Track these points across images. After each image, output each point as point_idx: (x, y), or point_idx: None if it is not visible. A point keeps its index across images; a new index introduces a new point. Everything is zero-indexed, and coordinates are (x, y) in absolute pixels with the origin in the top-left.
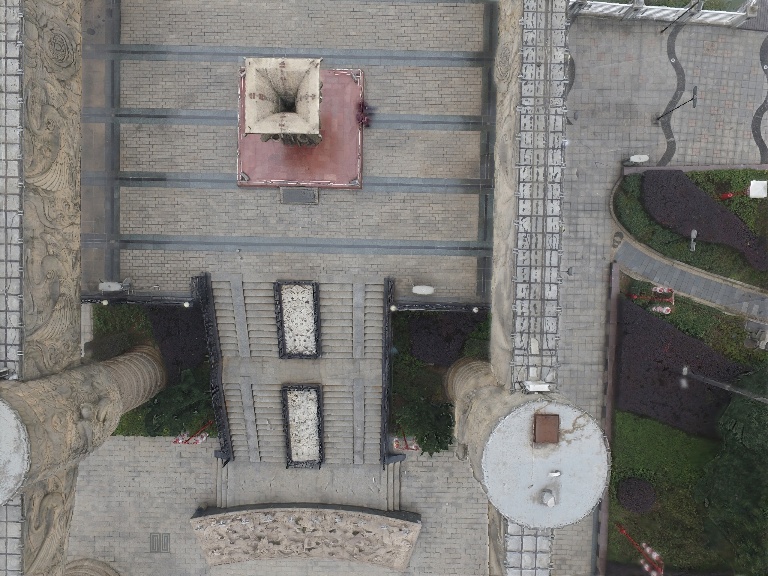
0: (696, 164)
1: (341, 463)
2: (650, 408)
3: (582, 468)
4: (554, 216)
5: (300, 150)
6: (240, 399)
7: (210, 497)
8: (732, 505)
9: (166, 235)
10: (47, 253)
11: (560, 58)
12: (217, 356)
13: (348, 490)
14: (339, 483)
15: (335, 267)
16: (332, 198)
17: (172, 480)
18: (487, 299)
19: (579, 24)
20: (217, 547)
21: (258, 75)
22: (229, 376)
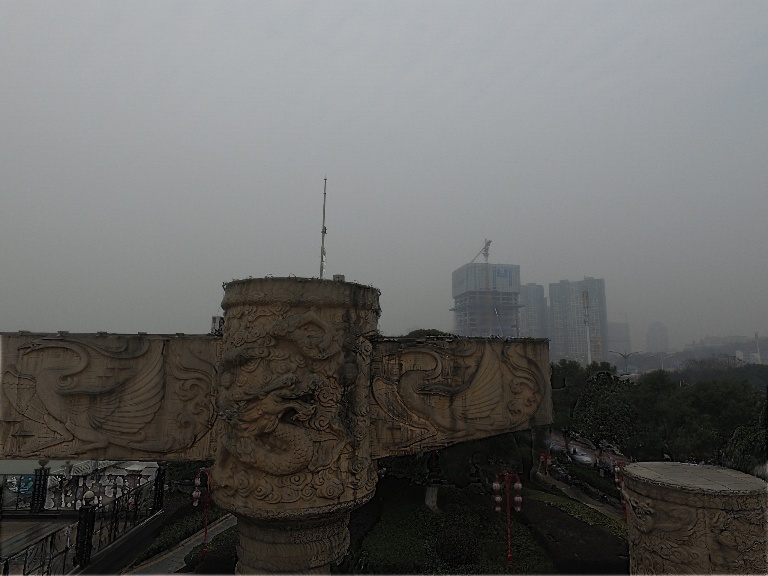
0: None
1: None
2: None
3: None
4: None
5: None
6: None
7: None
8: None
9: None
10: None
11: None
12: None
13: None
14: None
15: None
16: None
17: None
18: None
19: None
20: None
21: None
22: None
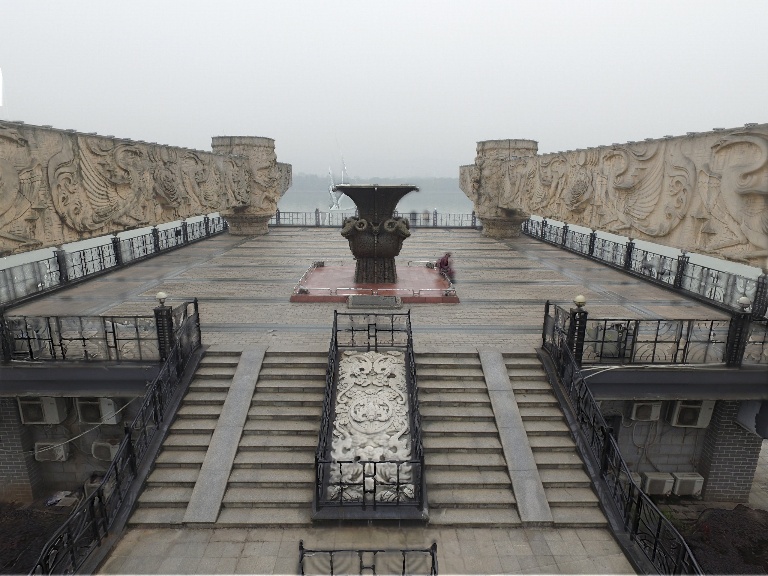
0: None
1: None
2: None
3: None
4: None
5: None
6: None
7: None
8: None
9: None
10: None
11: None
12: (116, 514)
13: None
14: None
15: (439, 341)
16: None
17: None
18: None
19: None
20: None
21: None
22: None
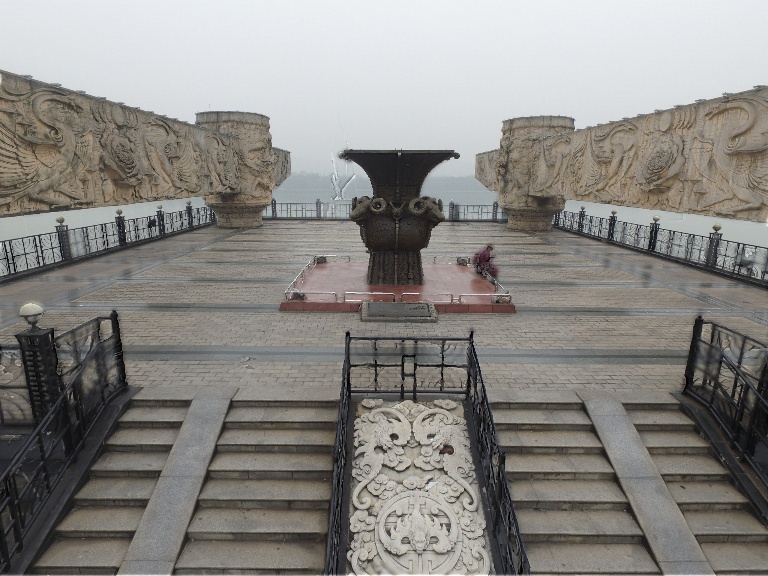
0: None
1: None
2: None
3: None
4: None
5: (396, 287)
6: None
7: None
8: None
9: None
10: None
11: None
12: None
13: None
14: None
15: (511, 379)
16: (463, 318)
17: None
18: None
19: None
20: None
21: None
22: None
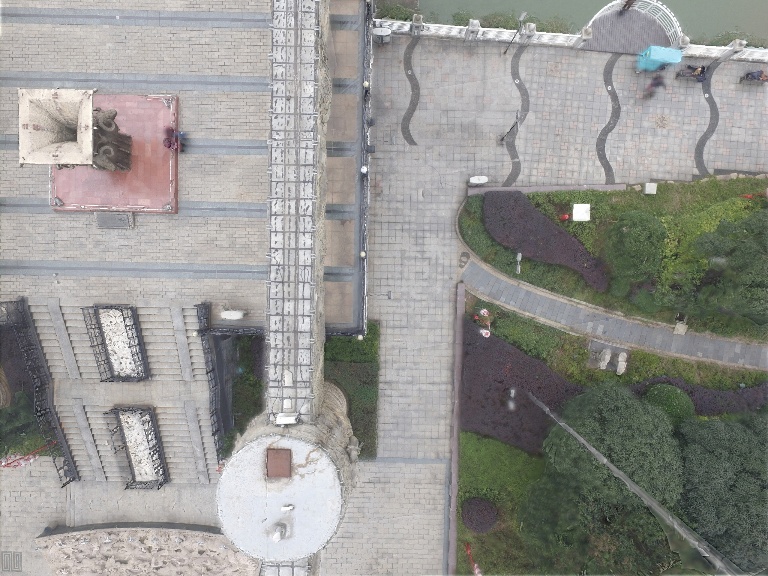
0: (541, 184)
1: (188, 482)
2: (491, 428)
3: (316, 502)
4: (306, 249)
5: (114, 175)
6: (75, 420)
7: (61, 516)
8: (537, 530)
9: None
10: None
11: (310, 92)
12: (46, 378)
13: (195, 509)
14: (186, 502)
15: (152, 291)
16: (148, 222)
17: (22, 499)
18: None
19: (423, 45)
20: (65, 566)
21: (32, 106)
22: (61, 398)
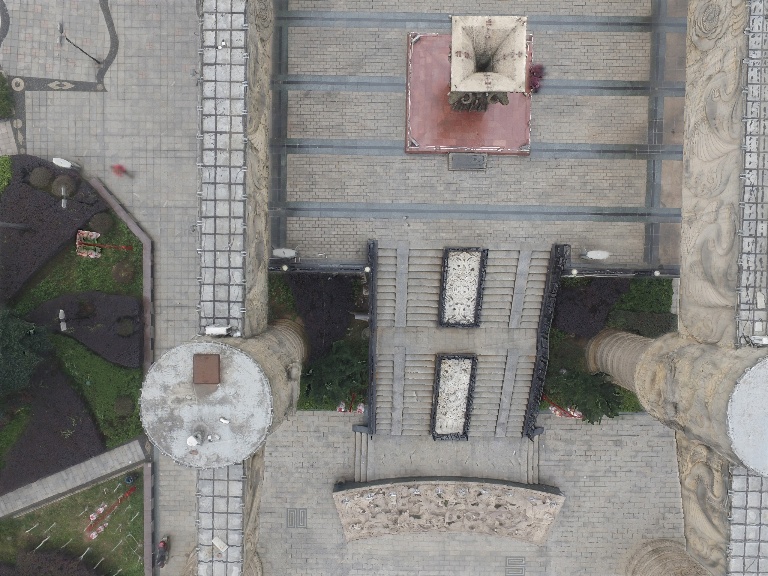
0: None
1: (482, 436)
2: None
3: None
4: None
5: (469, 116)
6: (391, 370)
7: (347, 472)
8: None
9: (333, 202)
10: (255, 212)
11: None
12: (373, 326)
13: (488, 463)
14: (479, 456)
15: (502, 234)
16: (499, 164)
17: (309, 455)
18: (654, 265)
19: None
20: (357, 521)
21: (464, 33)
22: (383, 346)
